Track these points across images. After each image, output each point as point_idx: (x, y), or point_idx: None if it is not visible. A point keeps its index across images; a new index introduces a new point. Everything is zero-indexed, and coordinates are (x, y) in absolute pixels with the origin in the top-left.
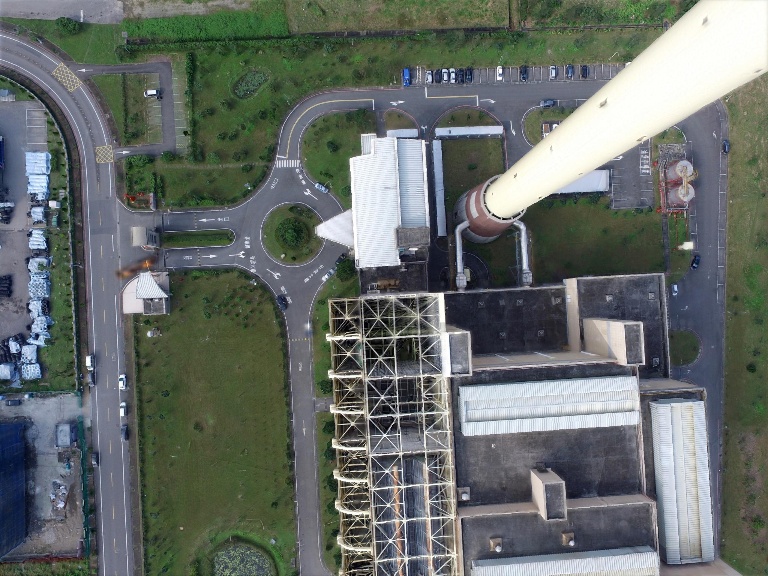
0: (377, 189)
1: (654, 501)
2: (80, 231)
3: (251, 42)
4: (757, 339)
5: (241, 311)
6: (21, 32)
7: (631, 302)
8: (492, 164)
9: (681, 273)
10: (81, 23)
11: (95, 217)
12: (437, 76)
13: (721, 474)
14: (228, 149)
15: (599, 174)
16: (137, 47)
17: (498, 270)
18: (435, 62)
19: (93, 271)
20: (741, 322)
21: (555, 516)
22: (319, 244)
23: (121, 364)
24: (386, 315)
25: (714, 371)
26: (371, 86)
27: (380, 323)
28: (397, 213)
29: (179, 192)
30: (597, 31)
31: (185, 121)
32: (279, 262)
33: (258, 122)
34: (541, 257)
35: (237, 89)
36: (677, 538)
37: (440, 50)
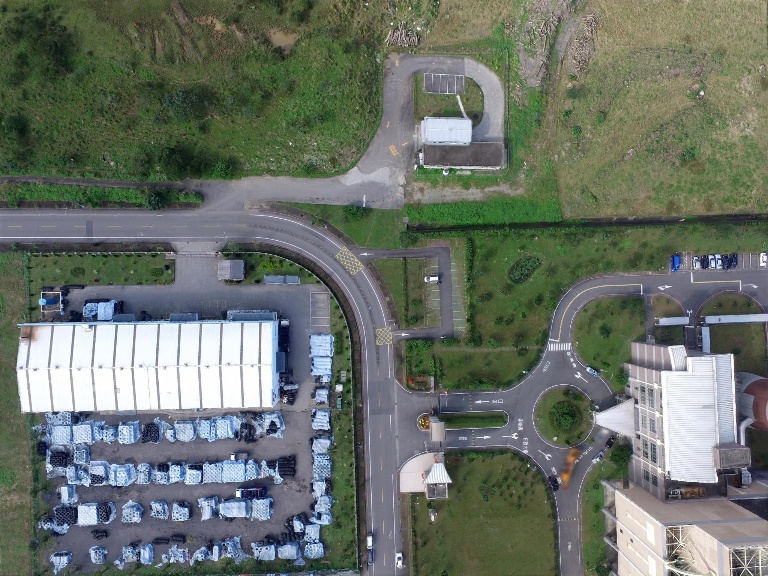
0: (694, 407)
1: None
2: (360, 411)
3: (531, 231)
4: None
5: (514, 492)
6: (315, 222)
7: None
8: (754, 348)
9: None
10: (364, 208)
11: (374, 398)
12: (704, 263)
13: None
14: (503, 333)
15: None
16: (421, 235)
17: (759, 452)
18: (701, 248)
19: (372, 451)
20: None
21: None
22: (589, 426)
23: (397, 542)
24: (753, 564)
25: None
26: (640, 271)
27: (747, 572)
28: (715, 431)
29: (456, 374)
30: None
31: (463, 305)
32: (550, 444)
33: (532, 306)
34: None
35: (512, 274)
36: None
37: (708, 238)
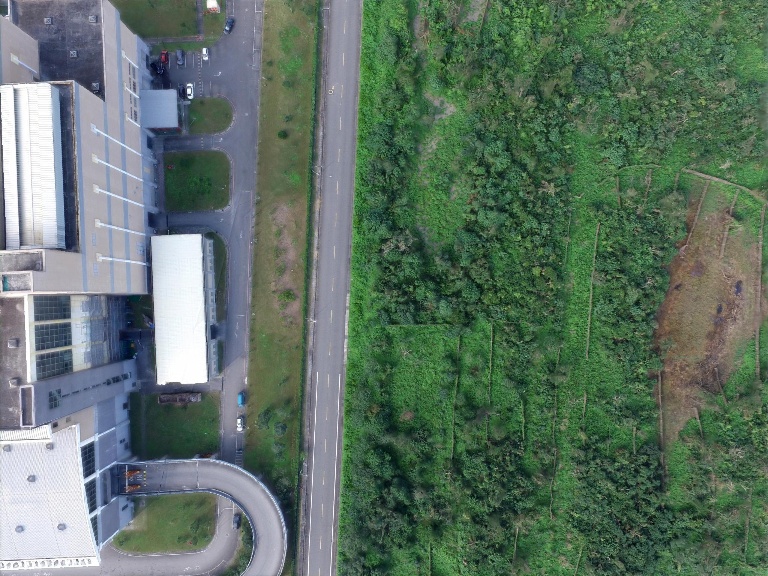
0: None
1: None
2: None
3: None
4: (292, 106)
5: None
6: None
7: (72, 26)
8: None
9: (215, 38)
10: None
11: None
12: None
13: (253, 246)
14: None
15: None
16: None
17: None
18: None
19: None
20: (276, 88)
21: None
22: None
23: None
24: None
25: (248, 140)
26: None
27: None
28: None
29: None
30: None
31: None
32: None
33: None
34: None
35: None
36: (16, 223)
37: None
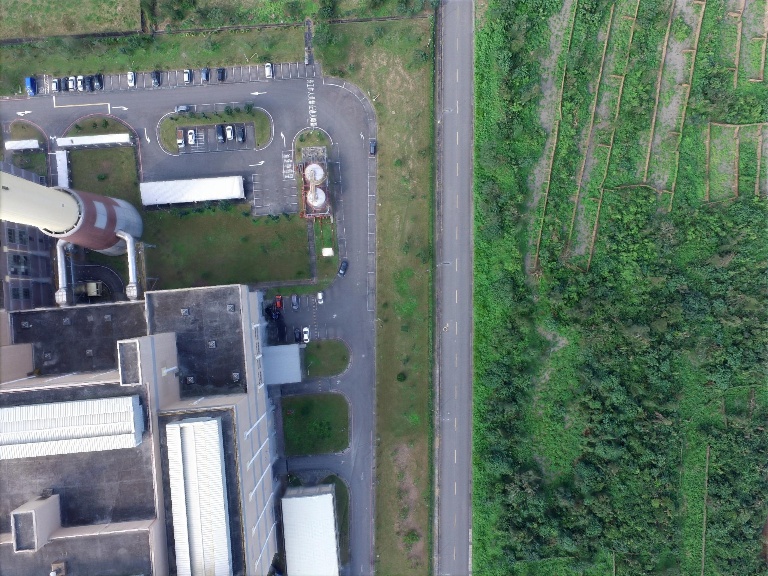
0: None
1: (150, 527)
2: None
3: None
4: (409, 346)
5: None
6: None
7: (209, 315)
8: (125, 173)
9: (329, 280)
10: None
11: None
12: (62, 84)
13: (375, 487)
14: None
15: (232, 181)
16: None
17: None
18: (62, 70)
19: None
20: (392, 329)
21: (27, 547)
22: None
23: None
24: None
25: (365, 381)
26: None
27: None
28: None
29: None
30: (233, 32)
31: None
32: None
33: None
34: (178, 268)
35: None
36: (188, 565)
37: (65, 57)
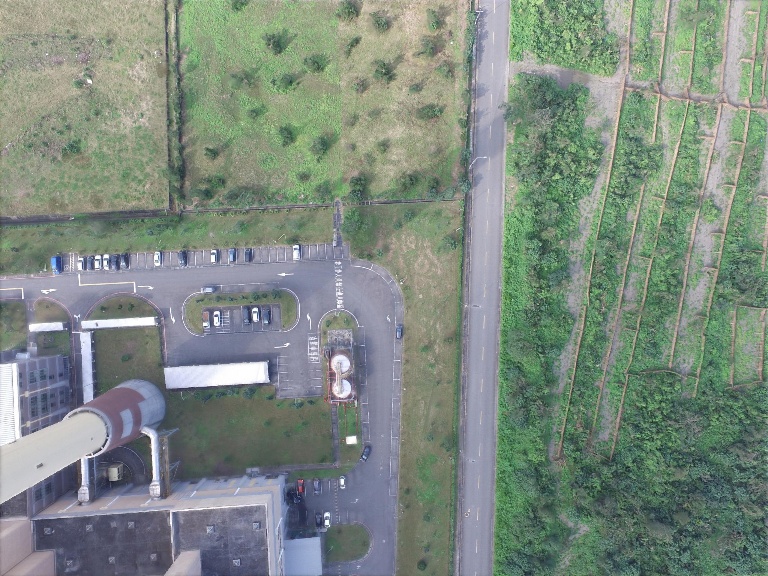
0: None
1: None
2: None
3: None
4: (430, 533)
5: None
6: None
7: (235, 532)
8: (149, 354)
9: (351, 464)
10: None
11: None
12: (88, 264)
13: None
14: None
15: (257, 366)
16: None
17: None
18: (88, 248)
19: None
20: (413, 516)
21: None
22: None
23: None
24: None
25: (385, 566)
26: (20, 274)
27: None
28: None
29: None
30: (261, 213)
31: None
32: None
33: None
34: (200, 451)
35: None
36: None
37: (91, 237)
